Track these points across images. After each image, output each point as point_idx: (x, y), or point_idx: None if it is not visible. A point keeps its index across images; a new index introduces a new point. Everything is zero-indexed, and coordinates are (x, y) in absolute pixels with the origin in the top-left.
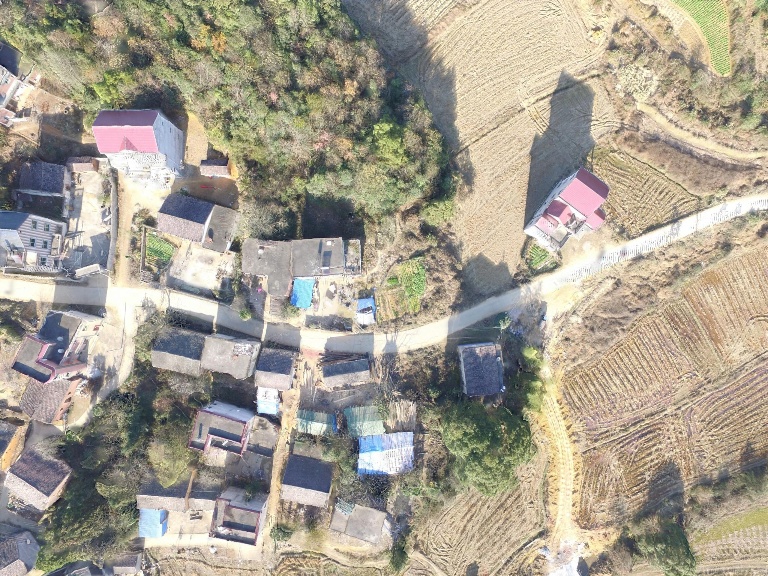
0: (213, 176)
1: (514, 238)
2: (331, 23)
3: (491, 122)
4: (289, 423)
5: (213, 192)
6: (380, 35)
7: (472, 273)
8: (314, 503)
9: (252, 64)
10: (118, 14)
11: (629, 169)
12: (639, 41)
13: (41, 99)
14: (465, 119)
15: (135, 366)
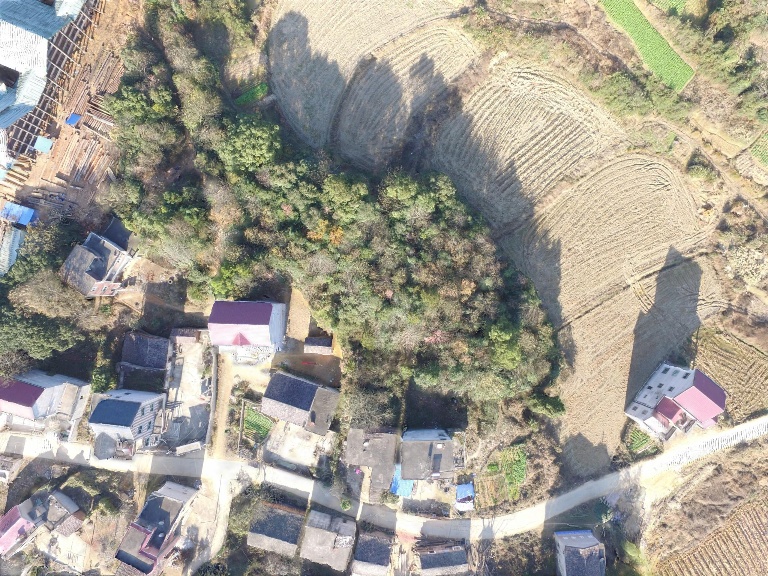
0: None
1: (614, 419)
2: (447, 214)
3: (595, 299)
4: None
5: (314, 367)
6: (485, 206)
7: (570, 454)
8: None
9: (369, 260)
10: (233, 199)
11: (735, 351)
12: (752, 222)
13: (146, 268)
14: (568, 295)
15: (227, 538)
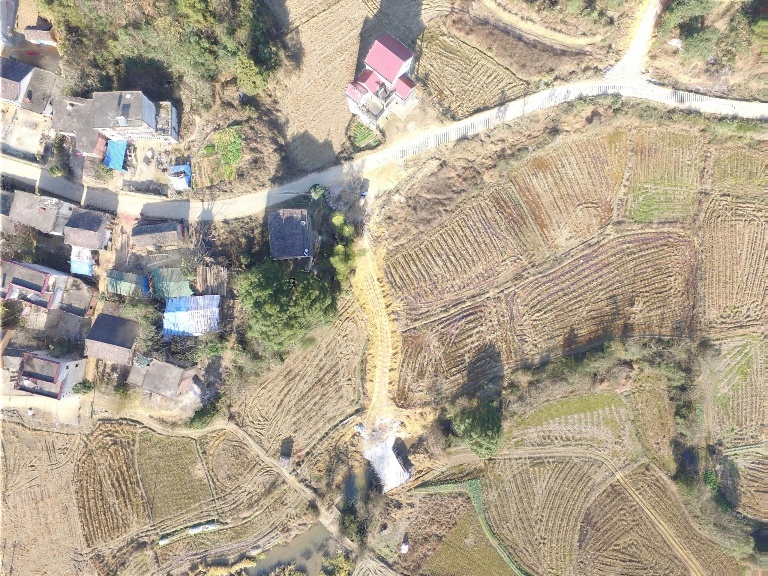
0: (41, 44)
1: (340, 117)
2: None
3: (321, 3)
4: (105, 286)
5: (40, 60)
6: None
7: (297, 150)
8: (119, 360)
9: None
10: None
11: (458, 53)
12: None
13: None
14: None
15: None
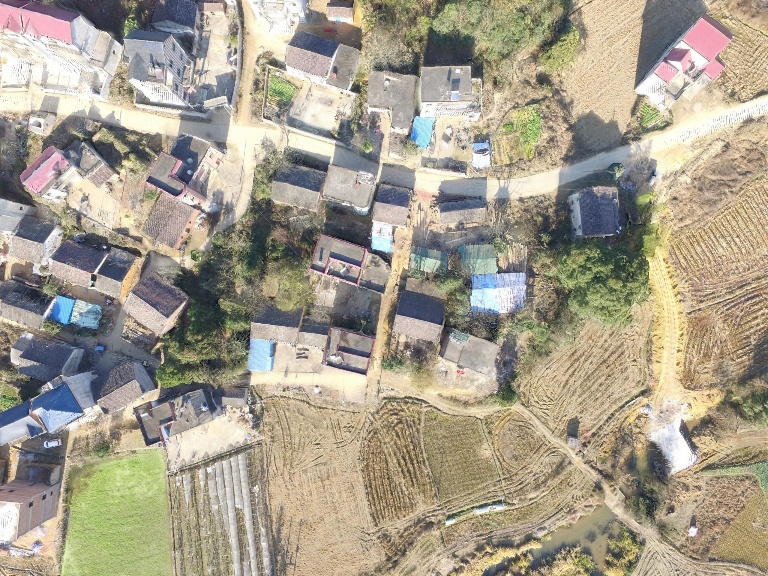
0: (336, 21)
1: (625, 97)
2: None
3: None
4: (400, 264)
5: (335, 37)
6: None
7: (582, 130)
8: (426, 337)
9: None
10: None
11: (740, 35)
12: None
13: None
14: None
15: (251, 203)
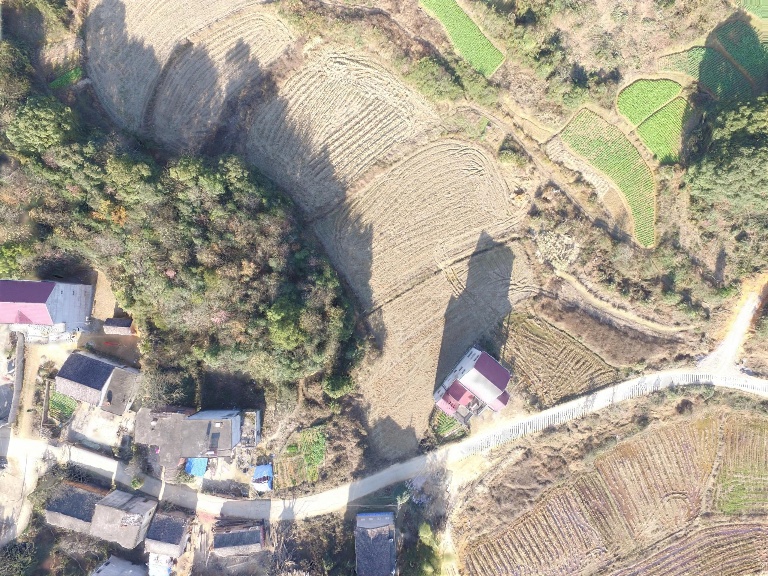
0: None
1: (423, 403)
2: (236, 195)
3: (406, 283)
4: None
5: (118, 348)
6: (298, 190)
7: (378, 436)
8: None
9: (150, 240)
10: (24, 180)
11: (546, 336)
12: (561, 207)
13: None
14: (379, 279)
15: (34, 516)
